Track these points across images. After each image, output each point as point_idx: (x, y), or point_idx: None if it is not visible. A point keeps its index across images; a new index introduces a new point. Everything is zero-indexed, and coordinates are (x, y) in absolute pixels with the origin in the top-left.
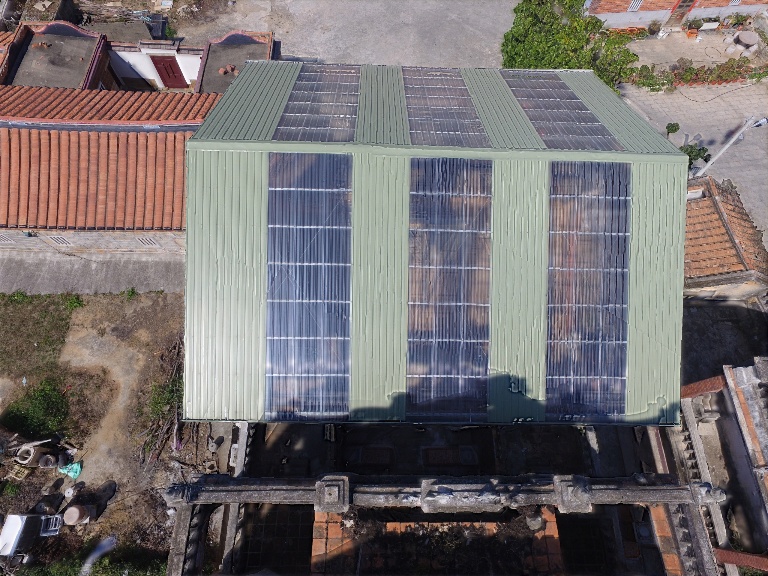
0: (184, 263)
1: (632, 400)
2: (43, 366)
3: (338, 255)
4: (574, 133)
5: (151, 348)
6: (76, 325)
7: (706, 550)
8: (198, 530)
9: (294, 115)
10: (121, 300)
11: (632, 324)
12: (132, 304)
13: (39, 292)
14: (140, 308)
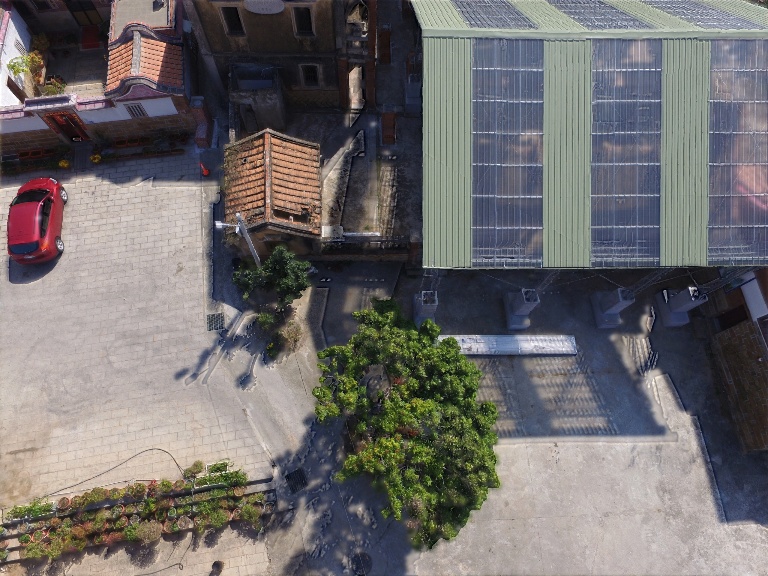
0: None
1: None
2: None
3: (675, 12)
4: (508, 77)
5: None
6: None
7: None
8: None
9: (767, 100)
10: None
11: (447, 1)
12: None
13: None
14: None
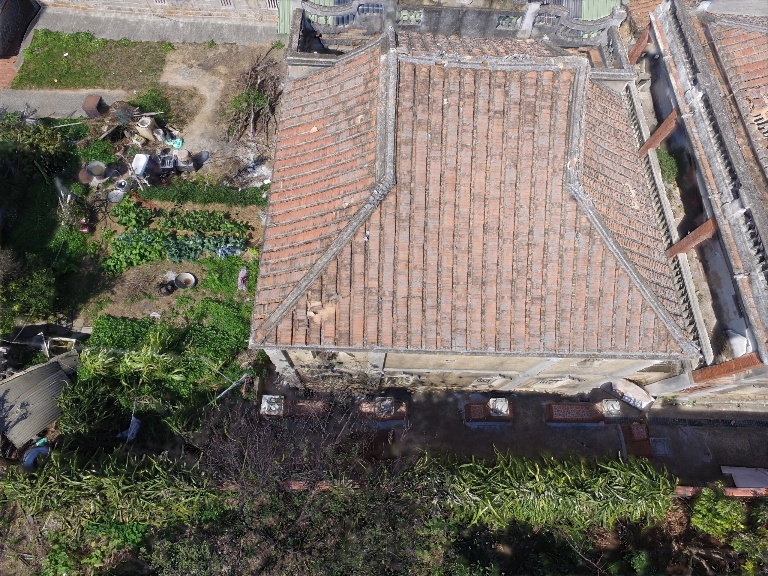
0: (251, 26)
1: (586, 35)
2: (148, 84)
3: None
4: None
5: (229, 77)
6: (170, 61)
7: (620, 44)
8: (303, 39)
9: None
10: (203, 48)
11: None
12: (212, 50)
13: (140, 40)
14: (218, 53)
